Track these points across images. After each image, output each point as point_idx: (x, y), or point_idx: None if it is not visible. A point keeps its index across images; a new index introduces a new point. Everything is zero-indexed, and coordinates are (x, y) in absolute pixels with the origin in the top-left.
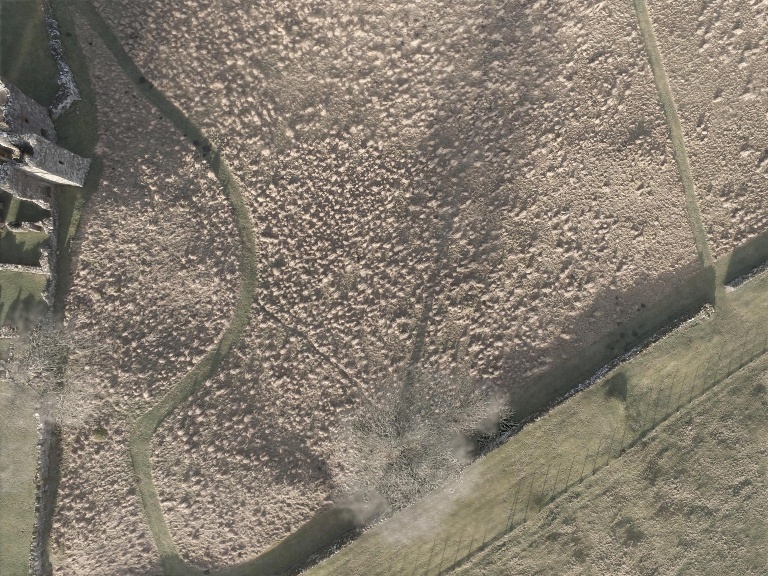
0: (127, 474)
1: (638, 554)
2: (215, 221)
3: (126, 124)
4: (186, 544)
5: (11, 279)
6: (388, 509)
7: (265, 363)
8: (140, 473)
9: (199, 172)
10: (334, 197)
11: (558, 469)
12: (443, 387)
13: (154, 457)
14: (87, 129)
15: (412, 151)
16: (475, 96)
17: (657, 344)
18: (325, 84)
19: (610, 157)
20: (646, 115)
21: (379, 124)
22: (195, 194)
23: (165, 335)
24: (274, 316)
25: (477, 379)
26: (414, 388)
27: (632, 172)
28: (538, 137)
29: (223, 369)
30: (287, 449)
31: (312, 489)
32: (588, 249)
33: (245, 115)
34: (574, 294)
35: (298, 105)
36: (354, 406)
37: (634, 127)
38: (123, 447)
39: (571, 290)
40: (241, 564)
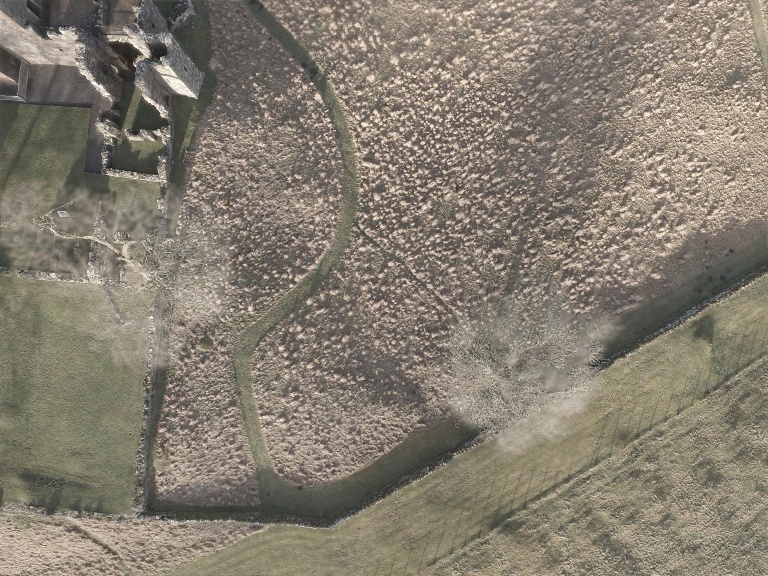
0: (230, 385)
1: (717, 496)
2: (320, 143)
3: (237, 42)
4: (282, 459)
5: (126, 186)
6: (479, 435)
7: (364, 286)
8: (242, 385)
9: (306, 94)
10: (435, 126)
11: (644, 407)
12: (535, 319)
13: (256, 370)
14: (201, 44)
15: (512, 85)
16: (576, 33)
17: (744, 289)
18: (430, 14)
19: (707, 100)
20: (743, 61)
21: (481, 56)
22: (302, 115)
23: (269, 252)
24: (373, 240)
25: (568, 314)
26: (507, 319)
27: (728, 117)
28: (637, 77)
29: (323, 289)
30: (382, 371)
31: (407, 411)
32: (680, 192)
33: (352, 40)
34: (665, 235)
35: (403, 33)
36: (449, 333)
37: (731, 72)
38: (227, 358)
39: (663, 231)
40: (334, 481)
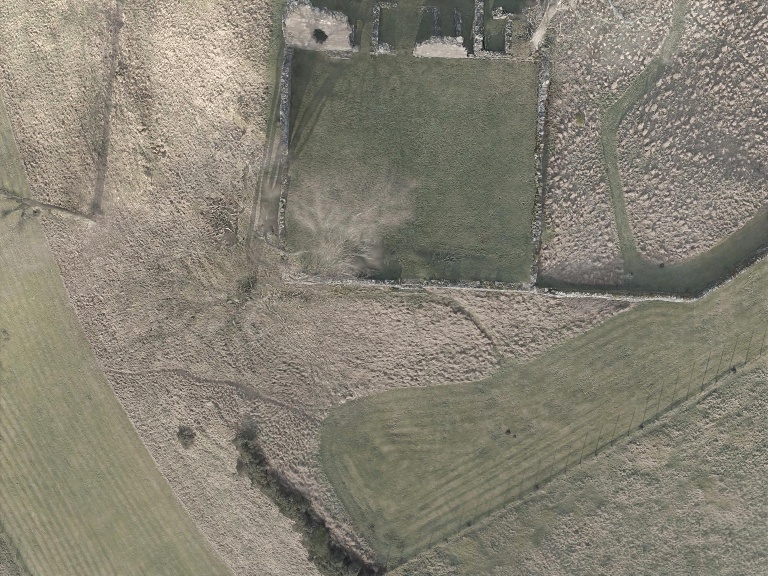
0: (600, 161)
1: None
2: None
3: None
4: (644, 237)
5: None
6: None
7: (703, 70)
8: (609, 162)
9: None
10: None
11: None
12: None
13: (621, 148)
14: None
15: None
16: None
17: None
18: None
19: None
20: None
21: None
22: None
23: (621, 35)
24: (705, 28)
25: None
26: None
27: None
28: None
29: (668, 73)
30: (727, 151)
31: (756, 186)
32: None
33: None
34: None
35: None
36: None
37: None
38: (597, 134)
39: None
40: (694, 257)
